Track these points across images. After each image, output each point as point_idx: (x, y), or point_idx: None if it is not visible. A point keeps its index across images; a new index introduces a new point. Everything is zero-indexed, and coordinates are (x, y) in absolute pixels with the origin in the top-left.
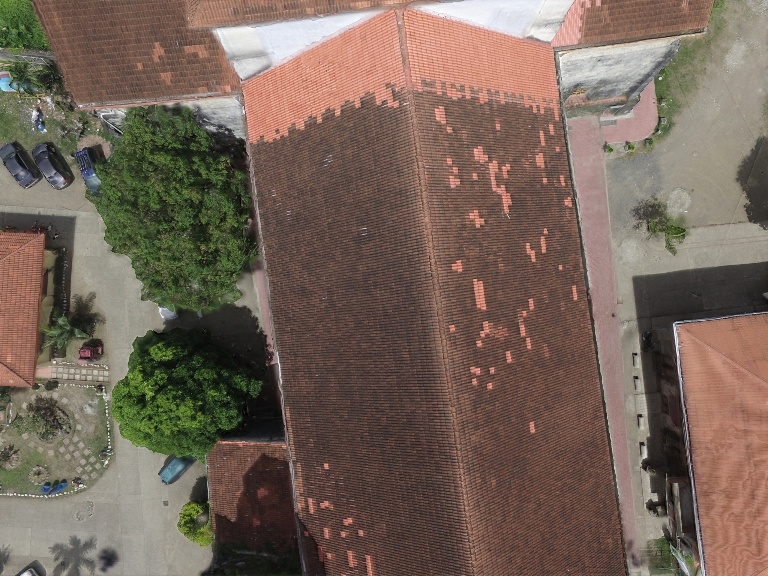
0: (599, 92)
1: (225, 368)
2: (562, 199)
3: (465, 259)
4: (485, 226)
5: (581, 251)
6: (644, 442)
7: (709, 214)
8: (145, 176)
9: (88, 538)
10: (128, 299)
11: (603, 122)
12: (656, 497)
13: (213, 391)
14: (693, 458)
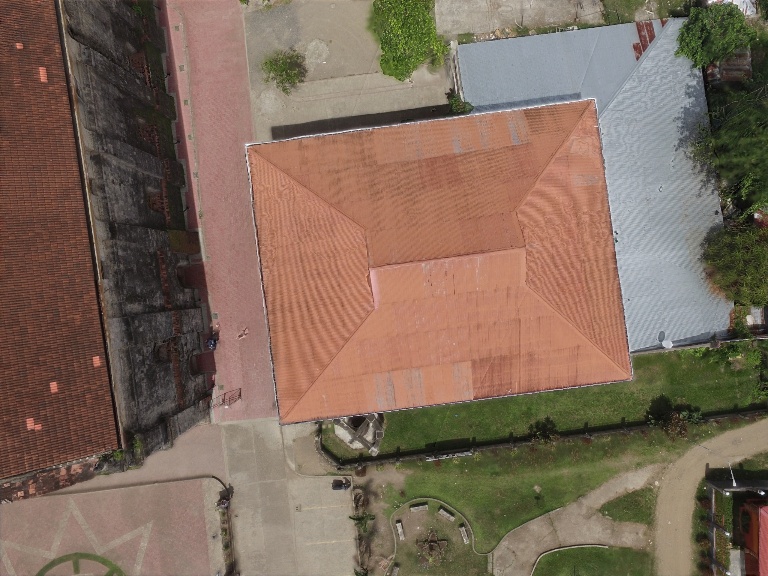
0: None
1: None
2: None
3: None
4: None
5: (62, 39)
6: None
7: (347, 65)
8: None
9: None
10: None
11: None
12: None
13: None
14: (263, 277)
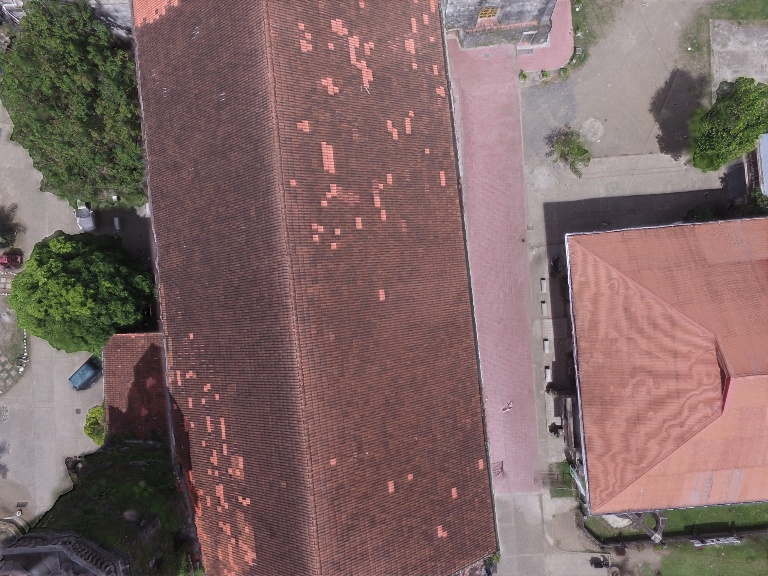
0: (508, 14)
1: (127, 267)
2: (433, 87)
3: (313, 121)
4: (339, 95)
5: (453, 141)
6: (549, 366)
7: (621, 144)
8: (37, 60)
9: (1, 443)
10: (49, 210)
11: (519, 51)
12: (559, 421)
13: (107, 281)
14: (580, 368)
